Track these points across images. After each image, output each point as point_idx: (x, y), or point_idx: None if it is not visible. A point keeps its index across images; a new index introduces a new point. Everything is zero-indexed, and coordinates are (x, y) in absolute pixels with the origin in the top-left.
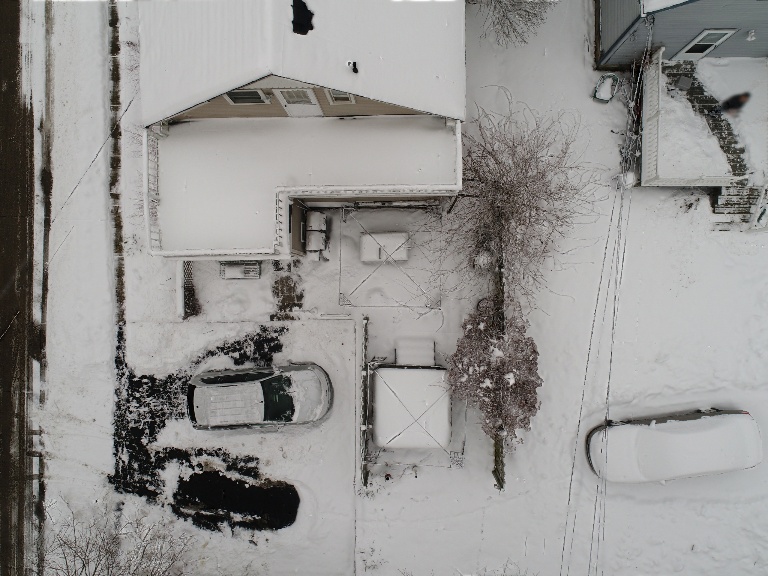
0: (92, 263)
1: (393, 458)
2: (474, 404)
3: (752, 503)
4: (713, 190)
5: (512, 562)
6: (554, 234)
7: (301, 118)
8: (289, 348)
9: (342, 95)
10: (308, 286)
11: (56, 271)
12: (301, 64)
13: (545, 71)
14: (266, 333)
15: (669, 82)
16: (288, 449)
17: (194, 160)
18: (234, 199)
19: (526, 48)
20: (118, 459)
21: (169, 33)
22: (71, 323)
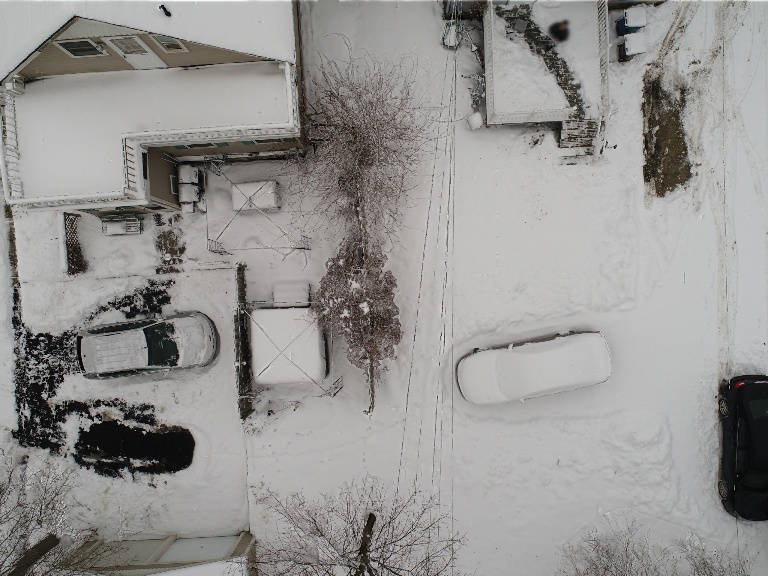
0: None
1: (277, 396)
2: (339, 336)
3: (610, 417)
4: None
5: (371, 476)
6: None
7: (148, 70)
8: (176, 299)
9: (171, 42)
10: (188, 238)
11: None
12: (106, 7)
13: (398, 23)
14: (154, 287)
15: (507, 26)
16: (180, 395)
17: (49, 114)
18: (89, 149)
19: (379, 2)
20: (20, 415)
21: None
22: None
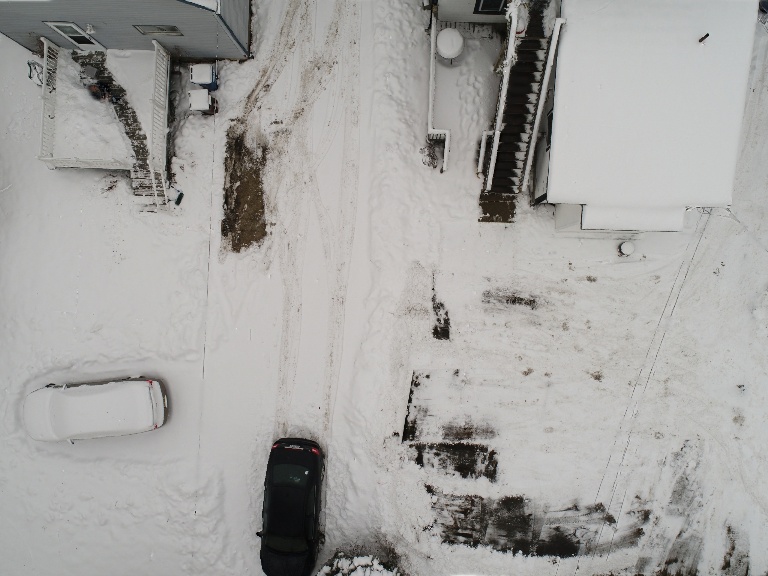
0: None
1: None
2: None
3: (166, 465)
4: None
5: None
6: (8, 209)
7: None
8: None
9: None
10: None
11: None
12: None
13: None
14: None
15: (82, 71)
16: None
17: None
18: None
19: None
20: None
21: None
22: None
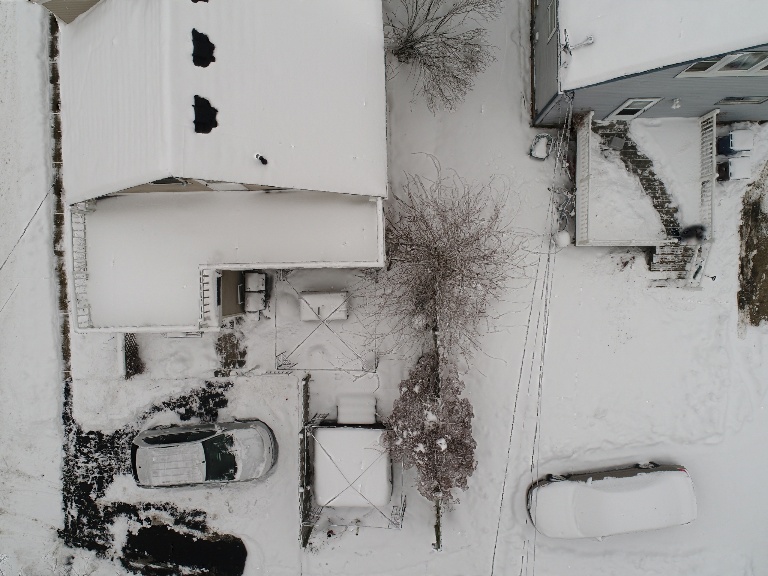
0: (37, 321)
1: (336, 513)
2: (410, 465)
3: (690, 556)
4: (649, 247)
5: None
6: None
7: (227, 192)
8: (234, 403)
9: None
10: (250, 343)
11: (2, 329)
12: (204, 163)
13: (482, 128)
14: (211, 388)
15: (602, 142)
16: (234, 504)
17: (121, 235)
18: (161, 274)
19: (463, 105)
20: (67, 514)
21: (86, 118)
22: (17, 381)
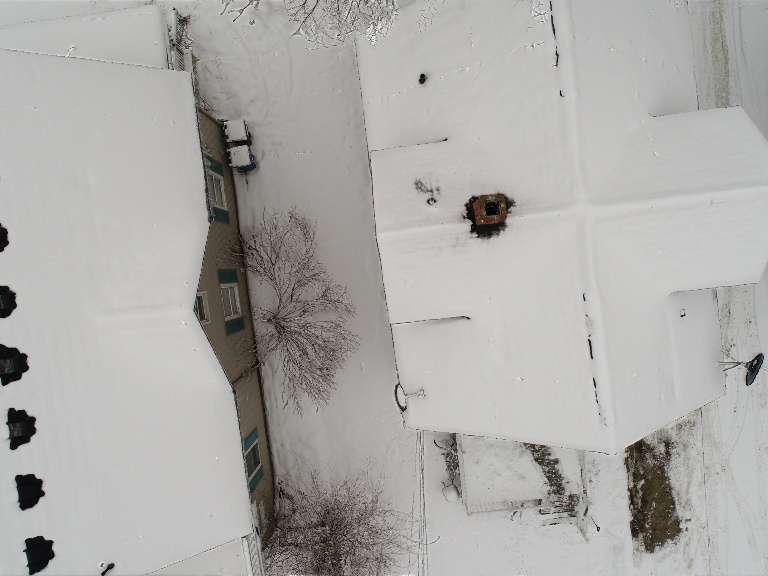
0: None
1: None
2: None
3: None
4: None
5: None
6: None
7: None
8: None
9: None
10: None
11: None
12: None
13: (365, 385)
14: None
15: None
16: None
17: None
18: None
19: (343, 364)
20: None
21: None
22: None
